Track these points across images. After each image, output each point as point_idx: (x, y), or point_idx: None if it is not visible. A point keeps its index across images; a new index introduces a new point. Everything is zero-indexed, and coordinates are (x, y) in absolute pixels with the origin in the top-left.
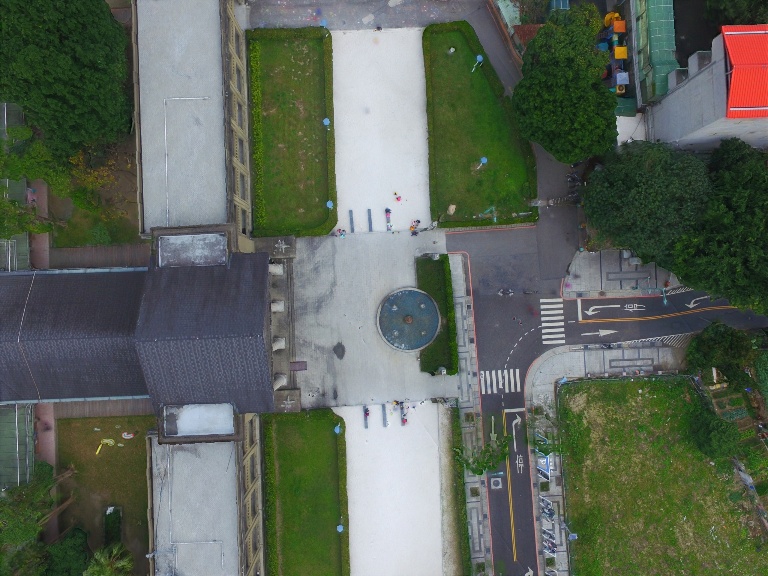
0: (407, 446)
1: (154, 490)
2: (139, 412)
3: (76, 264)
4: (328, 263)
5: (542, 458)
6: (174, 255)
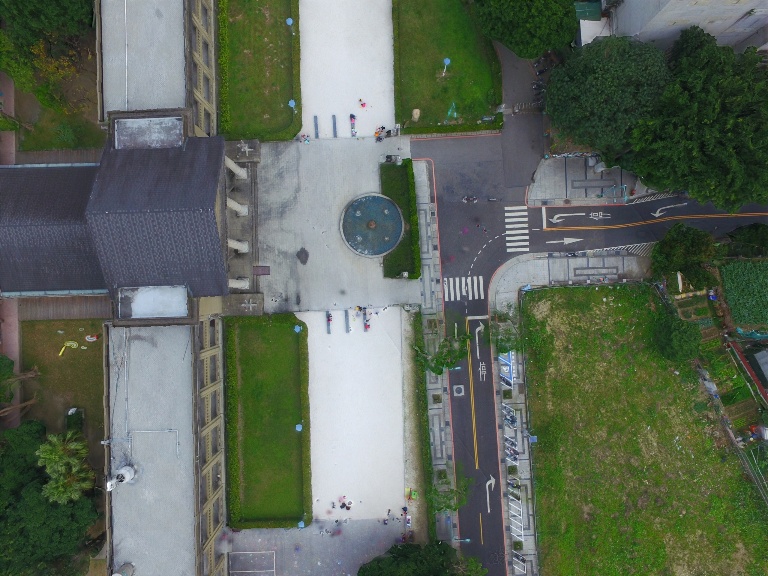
0: (370, 352)
1: (111, 378)
2: (103, 315)
3: None
4: (292, 169)
5: (505, 366)
6: (130, 139)
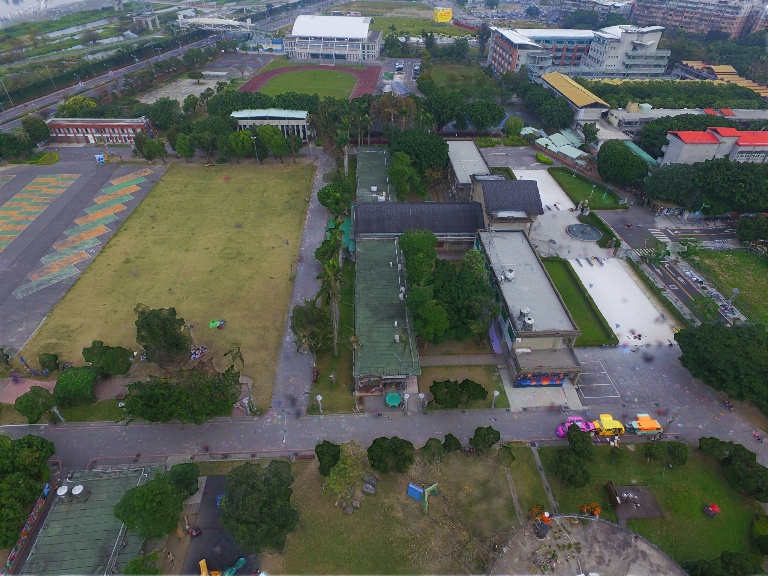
0: (609, 274)
1: None
2: (450, 259)
3: None
4: None
5: None
6: None
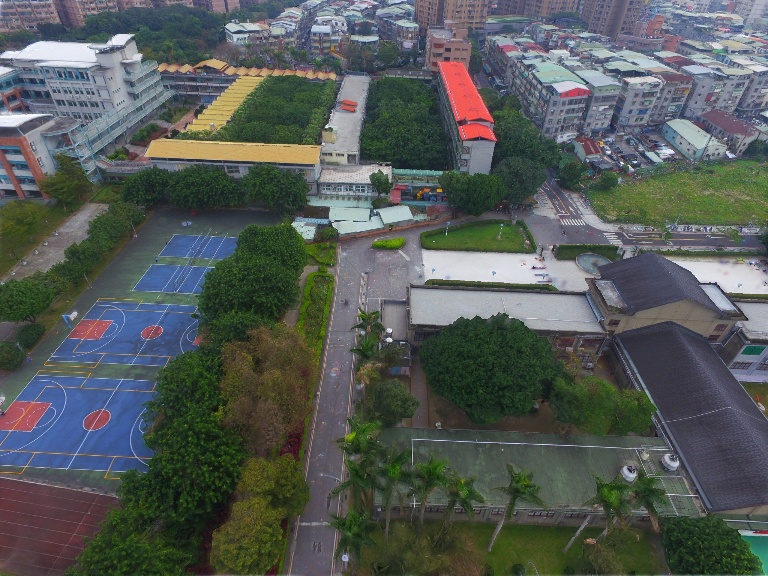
0: None
1: None
2: None
3: (636, 434)
4: None
5: (646, 229)
6: (618, 304)
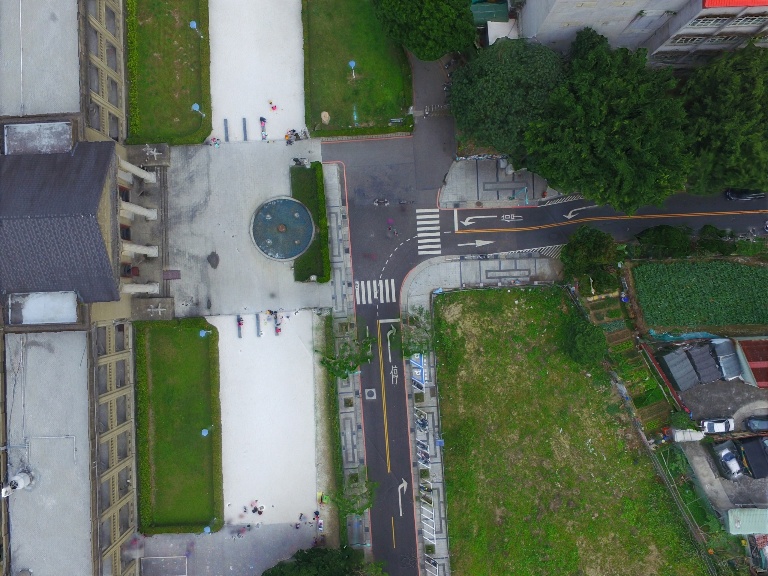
0: (281, 356)
1: (7, 385)
2: None
3: None
4: (203, 172)
5: (417, 369)
6: (20, 144)
